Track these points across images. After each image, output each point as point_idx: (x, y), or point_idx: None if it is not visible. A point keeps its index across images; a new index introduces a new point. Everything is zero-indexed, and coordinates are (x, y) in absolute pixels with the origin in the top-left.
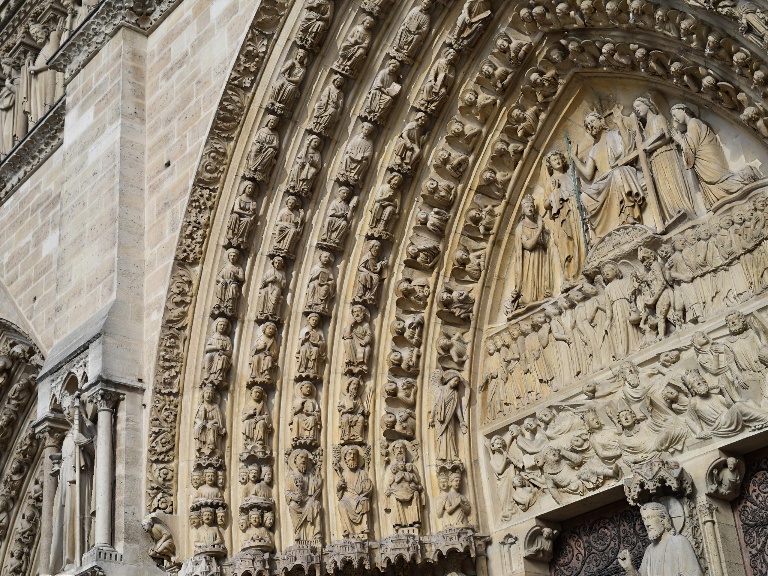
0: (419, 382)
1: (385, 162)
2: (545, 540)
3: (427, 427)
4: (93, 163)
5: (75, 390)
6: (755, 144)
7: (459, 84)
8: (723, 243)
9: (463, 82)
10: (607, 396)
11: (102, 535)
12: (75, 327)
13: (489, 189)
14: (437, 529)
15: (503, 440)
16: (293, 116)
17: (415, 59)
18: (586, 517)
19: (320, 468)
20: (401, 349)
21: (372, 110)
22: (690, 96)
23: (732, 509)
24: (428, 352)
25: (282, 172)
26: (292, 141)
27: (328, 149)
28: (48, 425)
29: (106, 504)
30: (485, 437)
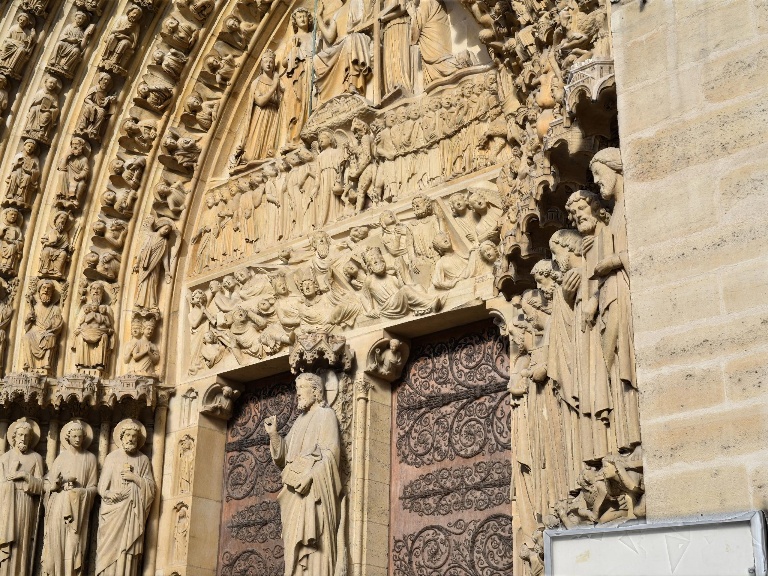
0: (131, 225)
1: None
2: (224, 398)
3: (131, 272)
4: None
5: None
6: (478, 29)
7: None
8: (428, 125)
9: None
10: (299, 263)
11: None
12: None
13: (232, 37)
14: (121, 374)
15: (204, 295)
16: None
17: None
18: (268, 381)
19: (13, 298)
20: (117, 189)
21: None
22: None
23: (392, 390)
24: (145, 196)
25: None
26: None
27: None
28: None
29: None
30: (189, 290)
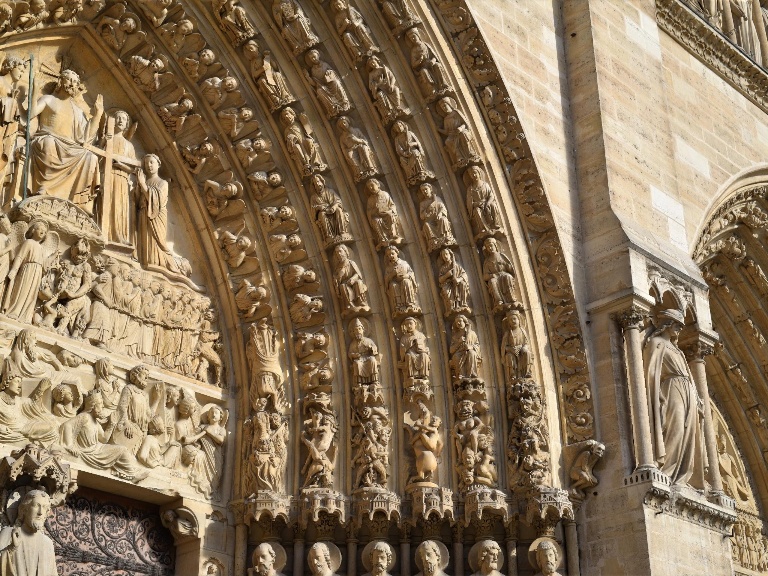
0: None
1: None
2: None
3: None
4: None
5: None
6: (187, 245)
7: None
8: None
9: None
10: None
11: None
12: None
13: None
14: None
15: None
16: None
17: None
18: None
19: None
20: None
21: None
22: (165, 159)
23: None
24: None
25: None
26: None
27: None
28: None
29: None
30: None
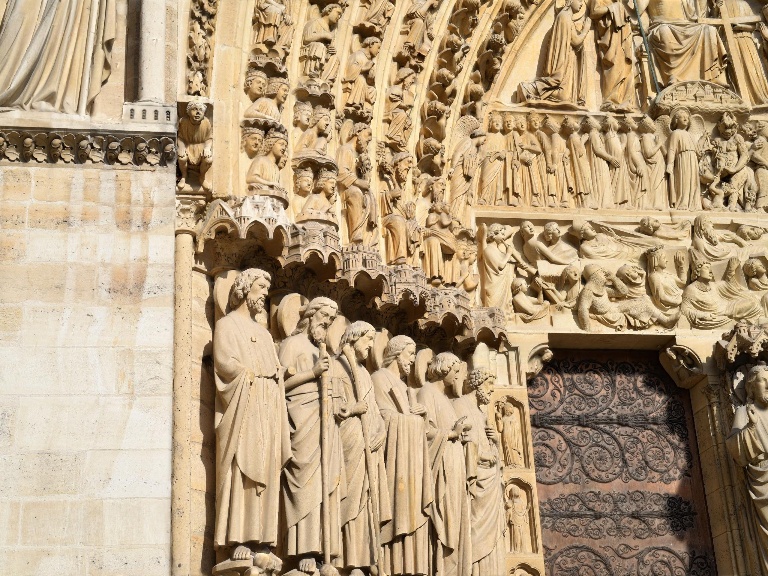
0: None
1: None
2: (540, 362)
3: (446, 176)
4: None
5: None
6: None
7: None
8: None
9: None
10: (671, 240)
11: (163, 88)
12: None
13: None
14: None
15: None
16: None
17: None
18: (570, 353)
19: None
20: None
21: None
22: None
23: None
24: None
25: None
26: None
27: None
28: None
29: None
30: (475, 219)
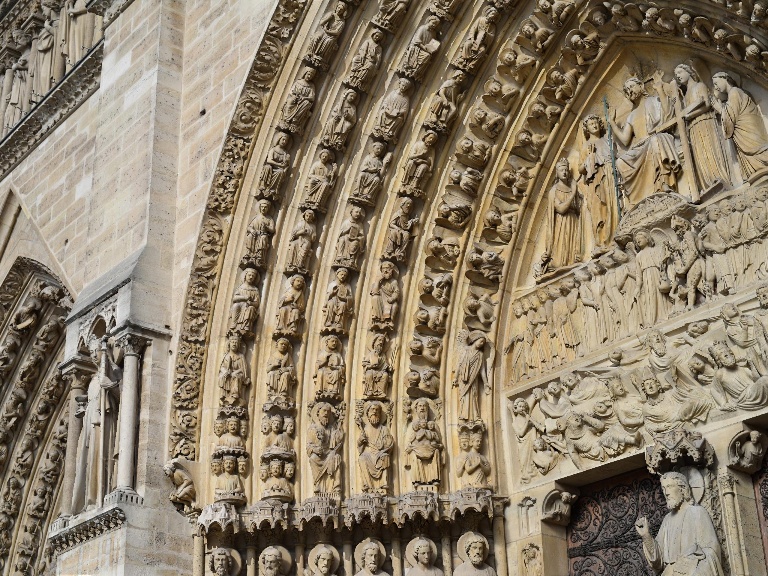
0: (445, 341)
1: (421, 119)
2: (563, 504)
3: (451, 386)
4: (129, 108)
5: (103, 334)
6: None
7: (499, 43)
8: (758, 215)
9: (503, 41)
10: (633, 364)
11: (124, 478)
12: (105, 271)
13: (524, 151)
14: (456, 488)
15: (526, 403)
16: (330, 69)
17: (455, 16)
18: (605, 483)
19: (342, 422)
20: (428, 307)
21: (410, 66)
22: (733, 65)
23: (753, 482)
24: (455, 312)
25: (317, 125)
26: (328, 94)
27: (364, 104)
28: (75, 367)
29: (129, 447)
30: (508, 399)
